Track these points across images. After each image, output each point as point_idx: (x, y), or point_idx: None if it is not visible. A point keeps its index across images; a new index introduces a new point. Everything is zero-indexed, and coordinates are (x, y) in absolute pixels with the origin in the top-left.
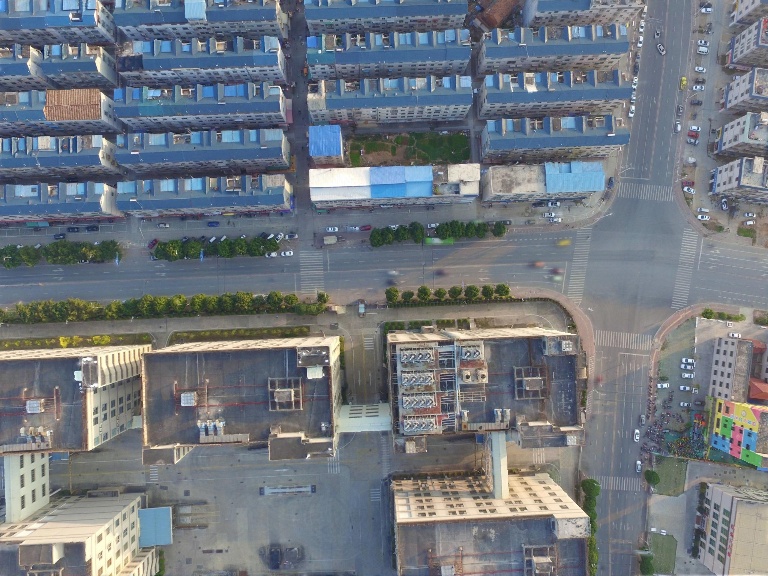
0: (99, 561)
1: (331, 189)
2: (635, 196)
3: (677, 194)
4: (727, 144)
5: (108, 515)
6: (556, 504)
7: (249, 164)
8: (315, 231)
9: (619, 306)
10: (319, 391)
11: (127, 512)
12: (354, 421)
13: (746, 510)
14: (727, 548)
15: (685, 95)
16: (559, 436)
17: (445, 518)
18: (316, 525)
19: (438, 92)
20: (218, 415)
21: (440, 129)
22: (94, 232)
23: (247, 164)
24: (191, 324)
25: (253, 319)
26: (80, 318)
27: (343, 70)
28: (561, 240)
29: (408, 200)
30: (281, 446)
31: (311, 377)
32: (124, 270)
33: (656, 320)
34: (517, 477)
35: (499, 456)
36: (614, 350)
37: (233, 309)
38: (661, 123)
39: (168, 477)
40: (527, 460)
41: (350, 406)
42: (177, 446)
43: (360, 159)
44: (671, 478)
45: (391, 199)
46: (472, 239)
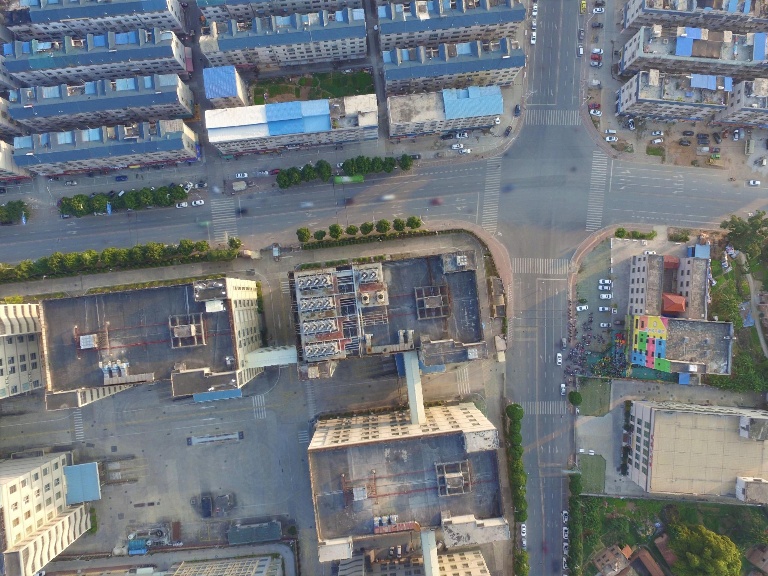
0: (13, 512)
1: (229, 129)
2: (543, 122)
3: (584, 117)
4: (627, 62)
5: (26, 470)
6: (469, 423)
7: (150, 114)
8: (225, 179)
9: (534, 232)
10: (221, 326)
11: (48, 468)
12: (263, 355)
13: (665, 420)
14: (648, 459)
15: (586, 19)
16: (461, 351)
17: (356, 442)
18: (246, 471)
19: (331, 26)
20: (121, 357)
21: (343, 68)
22: (1, 195)
23: (148, 114)
24: (106, 280)
25: (168, 271)
26: None
27: (237, 12)
28: (472, 171)
29: (310, 137)
30: (184, 381)
31: (210, 310)
32: (35, 231)
33: (571, 244)
34: (441, 407)
35: (413, 382)
36: (532, 276)
37: (147, 262)
38: (564, 48)
39: (94, 434)
40: (452, 391)
41: (267, 347)
42: (80, 389)
43: (264, 103)
44: (596, 399)
45: (291, 136)
46: (383, 176)
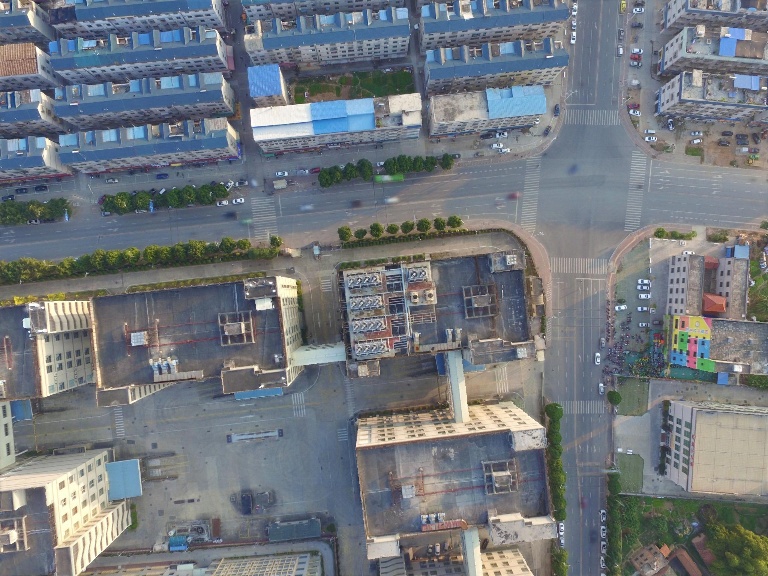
0: (63, 508)
1: (273, 128)
2: (582, 122)
3: (623, 117)
4: (668, 62)
5: (72, 466)
6: (514, 421)
7: (192, 112)
8: (265, 177)
9: (573, 232)
10: (270, 323)
11: (92, 464)
12: (309, 353)
13: (706, 420)
14: (689, 458)
15: (625, 19)
16: (510, 350)
17: (403, 440)
18: (285, 468)
19: (375, 25)
20: (171, 354)
21: (383, 67)
22: (43, 192)
23: (190, 112)
24: (147, 278)
25: (209, 269)
26: (33, 277)
27: (280, 11)
28: (511, 170)
29: (353, 136)
30: (234, 378)
31: (260, 308)
32: (76, 228)
33: (610, 244)
34: (481, 406)
35: (457, 380)
36: (570, 276)
37: (188, 259)
38: (603, 48)
39: (134, 431)
40: (491, 390)
41: (309, 346)
42: (131, 386)
43: (305, 102)
44: (634, 398)
45: (335, 135)
46: (422, 175)
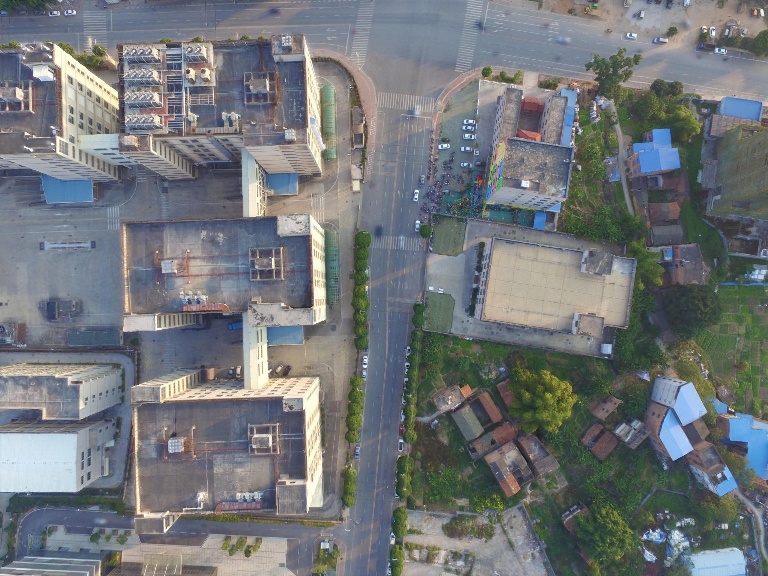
0: None
1: None
2: None
3: None
4: None
5: None
6: None
7: None
8: None
9: (402, 68)
10: (51, 96)
11: None
12: (96, 137)
13: (505, 249)
14: (485, 287)
15: None
16: (281, 134)
17: None
18: (95, 280)
19: None
20: None
21: None
22: None
23: None
24: None
25: None
26: None
27: None
28: (345, 2)
29: None
30: (5, 141)
31: (36, 75)
32: None
33: (439, 83)
34: None
35: (247, 181)
36: (396, 112)
37: None
38: None
39: None
40: None
41: None
42: None
43: None
44: (450, 238)
45: None
46: (255, 0)
